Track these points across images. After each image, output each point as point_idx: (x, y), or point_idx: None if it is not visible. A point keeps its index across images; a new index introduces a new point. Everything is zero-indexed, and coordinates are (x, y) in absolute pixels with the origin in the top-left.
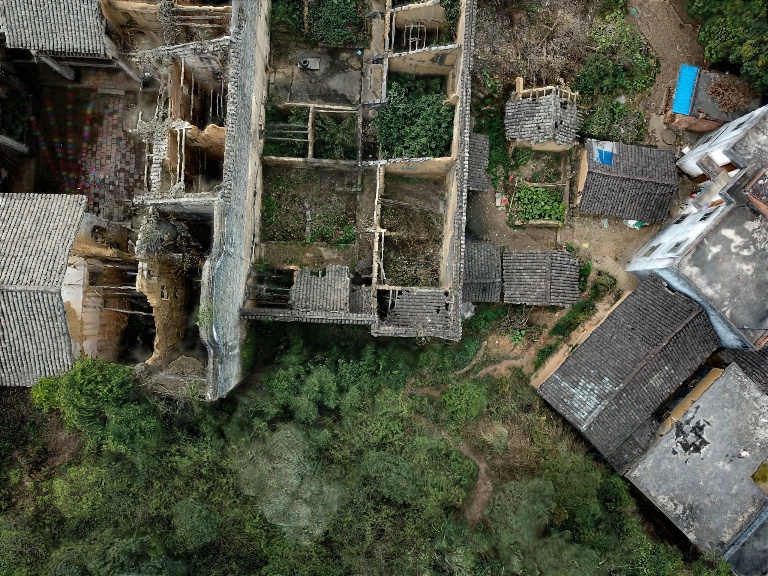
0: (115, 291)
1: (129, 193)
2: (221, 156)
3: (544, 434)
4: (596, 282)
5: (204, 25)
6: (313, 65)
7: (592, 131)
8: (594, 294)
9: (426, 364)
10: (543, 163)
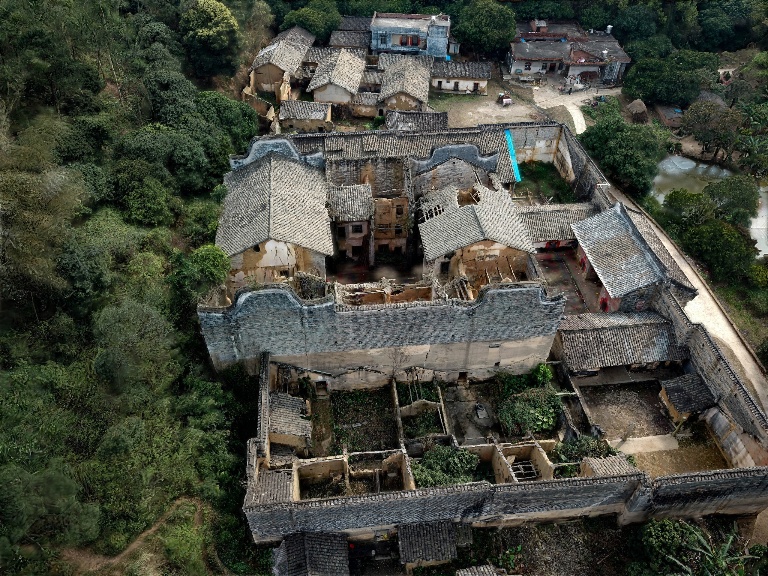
0: None
1: None
2: None
3: None
4: None
5: None
6: (481, 413)
7: None
8: None
9: None
10: None
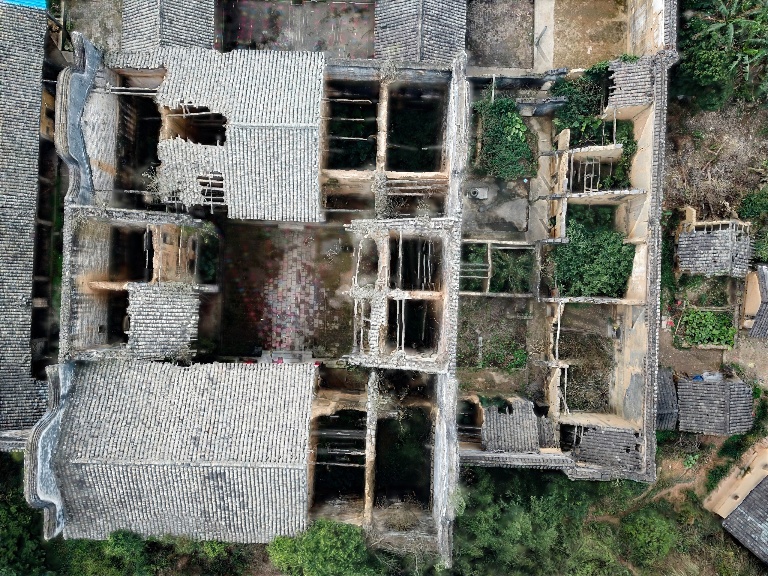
0: (323, 438)
1: (309, 323)
2: (416, 304)
3: (734, 570)
4: (764, 404)
5: (415, 194)
6: (481, 195)
7: (761, 257)
8: (762, 415)
9: (608, 494)
10: (709, 286)
